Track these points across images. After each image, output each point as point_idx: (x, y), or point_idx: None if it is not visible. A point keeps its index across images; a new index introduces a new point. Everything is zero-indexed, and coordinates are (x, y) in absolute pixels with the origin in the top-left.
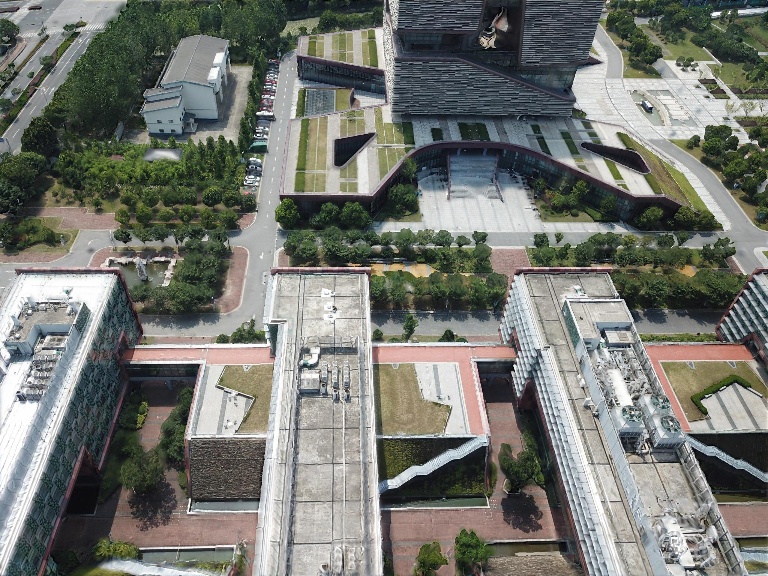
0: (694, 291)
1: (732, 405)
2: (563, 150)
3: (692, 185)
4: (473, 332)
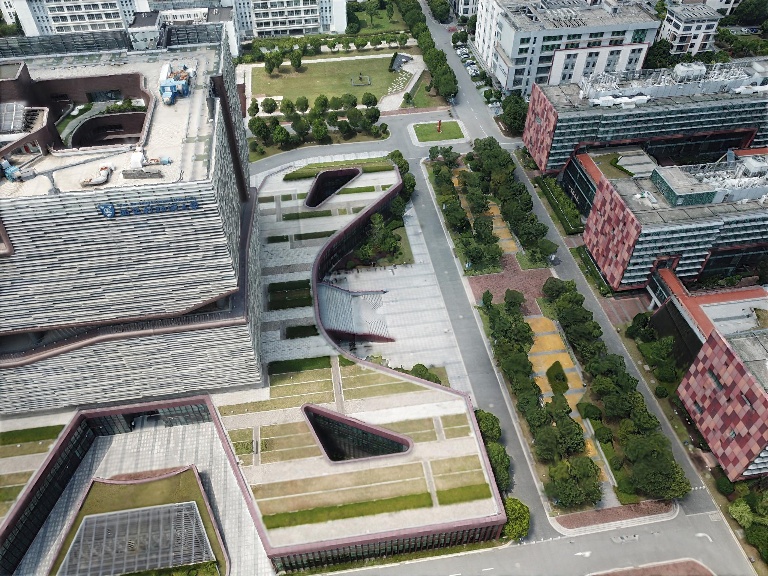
0: (512, 173)
1: (638, 169)
2: (323, 221)
3: (329, 161)
4: (605, 319)
